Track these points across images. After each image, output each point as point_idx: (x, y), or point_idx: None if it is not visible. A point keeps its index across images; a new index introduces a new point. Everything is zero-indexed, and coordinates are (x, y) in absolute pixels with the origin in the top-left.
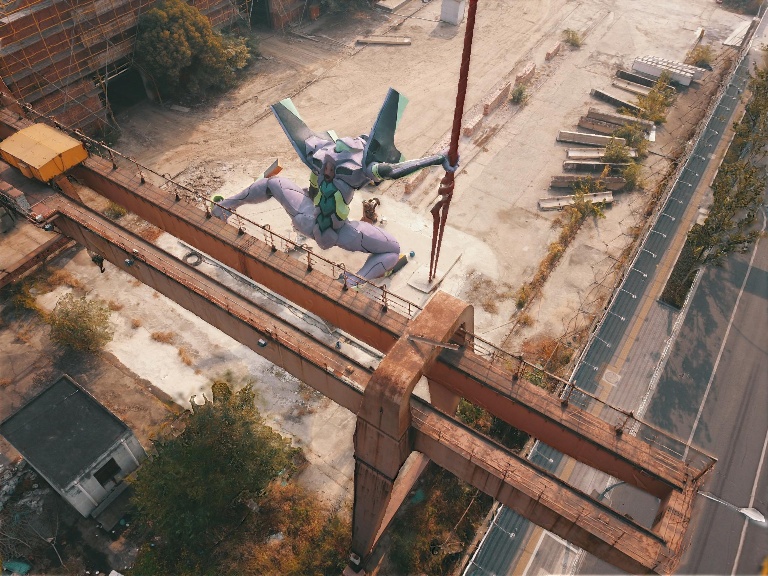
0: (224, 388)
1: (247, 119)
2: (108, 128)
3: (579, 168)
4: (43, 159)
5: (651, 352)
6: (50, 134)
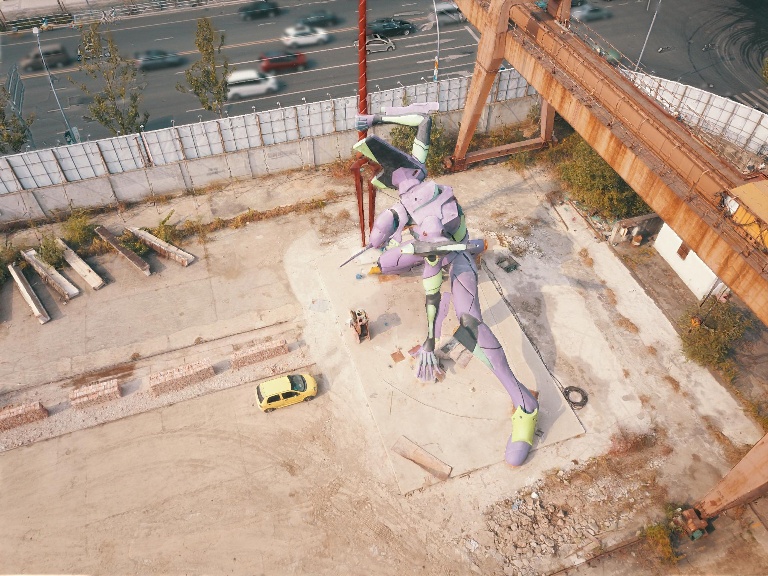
0: (603, 180)
1: None
2: None
3: None
4: (767, 185)
5: None
6: (766, 215)
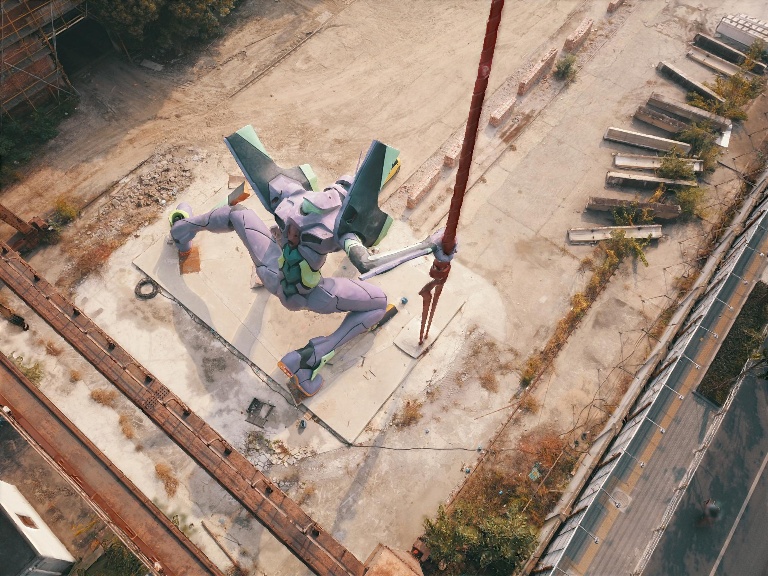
0: None
1: (230, 85)
2: (64, 93)
3: (626, 183)
4: None
5: (674, 466)
6: None
